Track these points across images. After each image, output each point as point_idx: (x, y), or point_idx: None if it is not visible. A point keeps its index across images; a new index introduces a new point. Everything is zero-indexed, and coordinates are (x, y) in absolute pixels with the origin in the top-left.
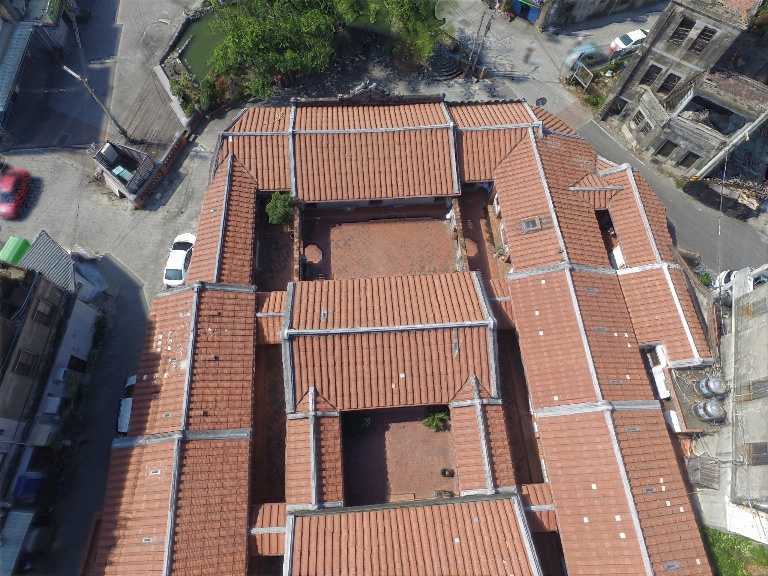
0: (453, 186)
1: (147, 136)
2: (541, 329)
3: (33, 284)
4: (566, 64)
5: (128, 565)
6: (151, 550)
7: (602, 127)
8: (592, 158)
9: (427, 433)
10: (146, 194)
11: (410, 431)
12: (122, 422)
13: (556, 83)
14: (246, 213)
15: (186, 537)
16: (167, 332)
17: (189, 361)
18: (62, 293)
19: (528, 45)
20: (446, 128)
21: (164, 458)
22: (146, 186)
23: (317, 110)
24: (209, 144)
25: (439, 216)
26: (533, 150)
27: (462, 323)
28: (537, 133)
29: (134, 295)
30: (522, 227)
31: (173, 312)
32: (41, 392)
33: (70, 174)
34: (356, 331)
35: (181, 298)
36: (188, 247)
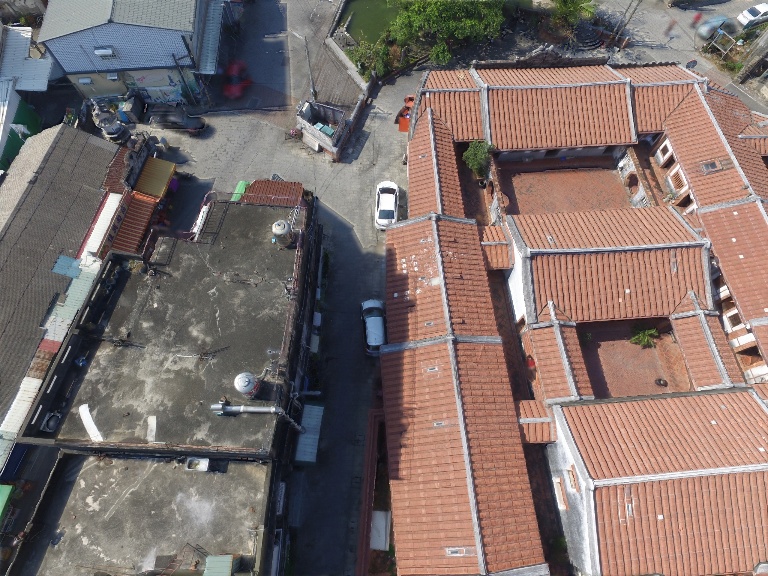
0: (630, 135)
1: (330, 99)
2: (741, 253)
3: (314, 206)
4: (698, 35)
5: (424, 445)
6: (446, 431)
7: (742, 89)
8: (748, 112)
9: (635, 350)
10: (340, 149)
11: (620, 348)
12: (371, 337)
13: (692, 51)
14: (450, 159)
15: (474, 421)
16: (410, 256)
17: (442, 277)
18: (317, 221)
19: (660, 19)
20: (623, 83)
21: (439, 357)
22: (342, 141)
23: (495, 71)
24: (385, 106)
25: (608, 166)
26: (702, 103)
27: (681, 243)
28: (702, 88)
29: (347, 235)
30: (702, 169)
31: (412, 239)
32: (313, 305)
33: (266, 132)
34: (588, 251)
35: (418, 227)
36: (392, 192)
